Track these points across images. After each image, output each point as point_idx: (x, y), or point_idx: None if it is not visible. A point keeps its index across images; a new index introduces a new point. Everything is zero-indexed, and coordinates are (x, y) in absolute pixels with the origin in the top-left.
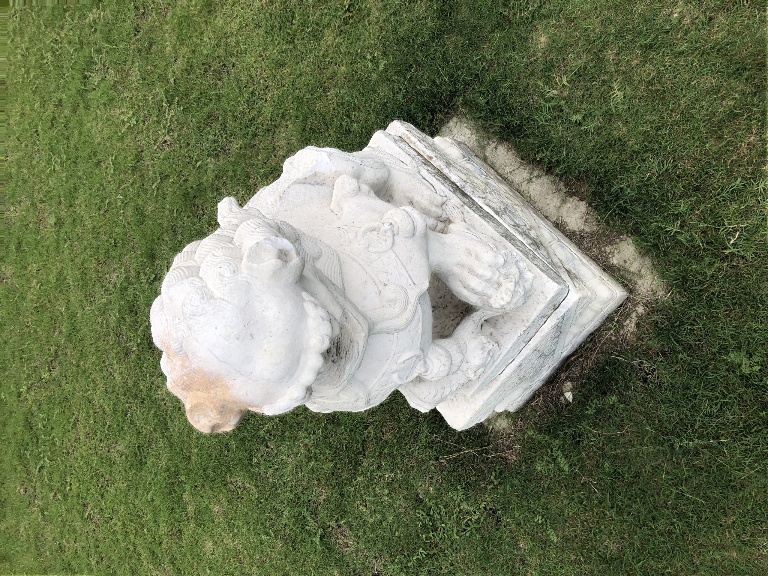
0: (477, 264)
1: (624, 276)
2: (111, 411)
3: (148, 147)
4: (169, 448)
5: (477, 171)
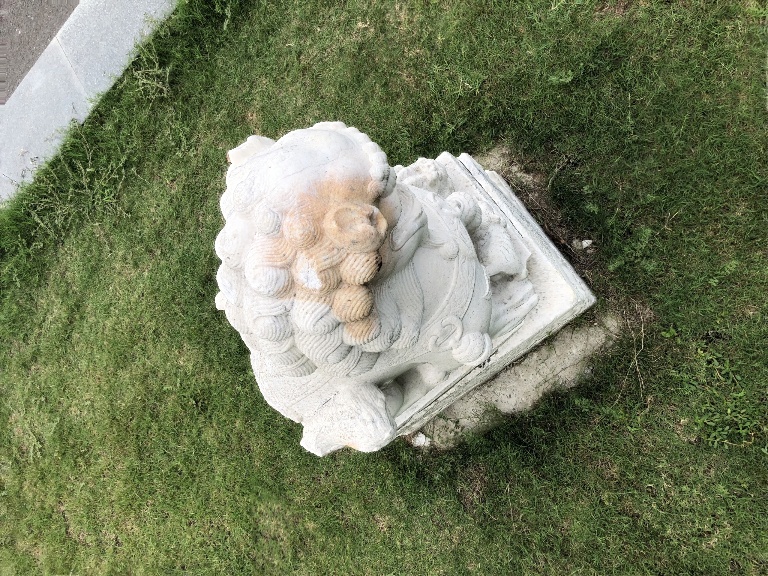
0: None
1: None
2: None
3: None
4: None
5: None
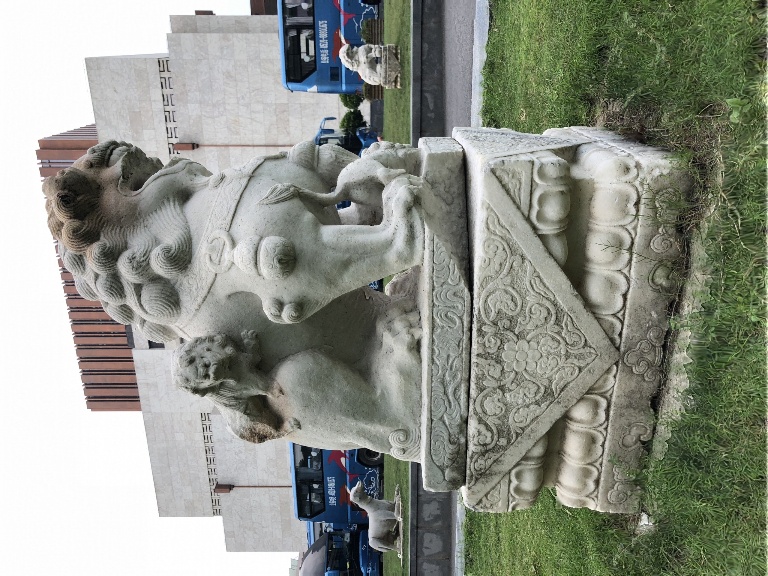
0: None
1: None
2: None
3: None
4: None
5: None
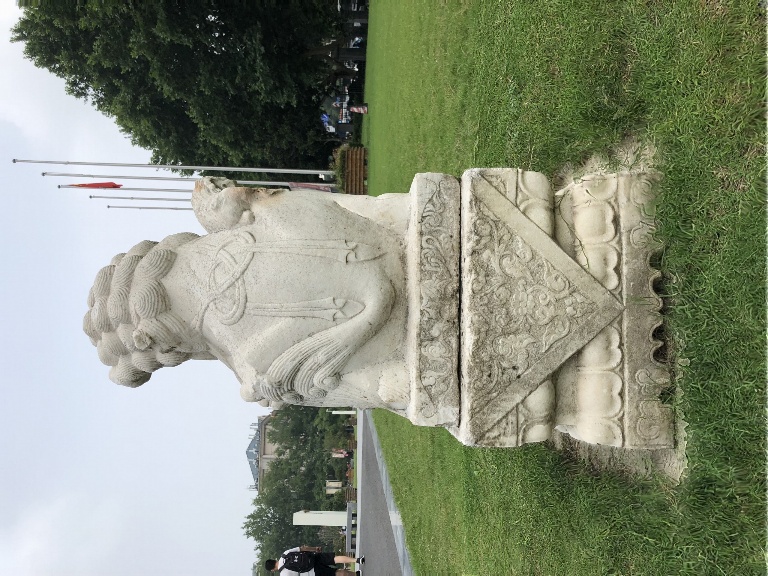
0: None
1: None
2: None
3: None
4: None
5: None
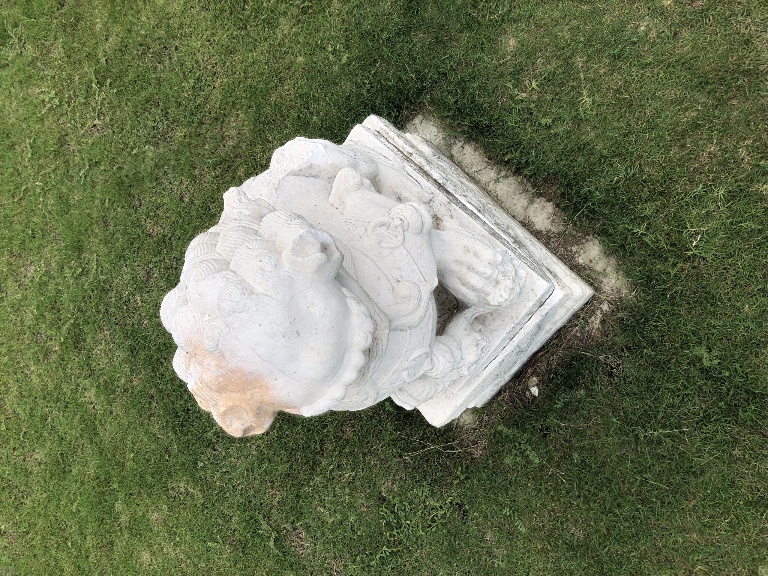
0: (477, 261)
1: (590, 275)
2: (28, 416)
3: (74, 131)
4: (99, 454)
5: (449, 169)
